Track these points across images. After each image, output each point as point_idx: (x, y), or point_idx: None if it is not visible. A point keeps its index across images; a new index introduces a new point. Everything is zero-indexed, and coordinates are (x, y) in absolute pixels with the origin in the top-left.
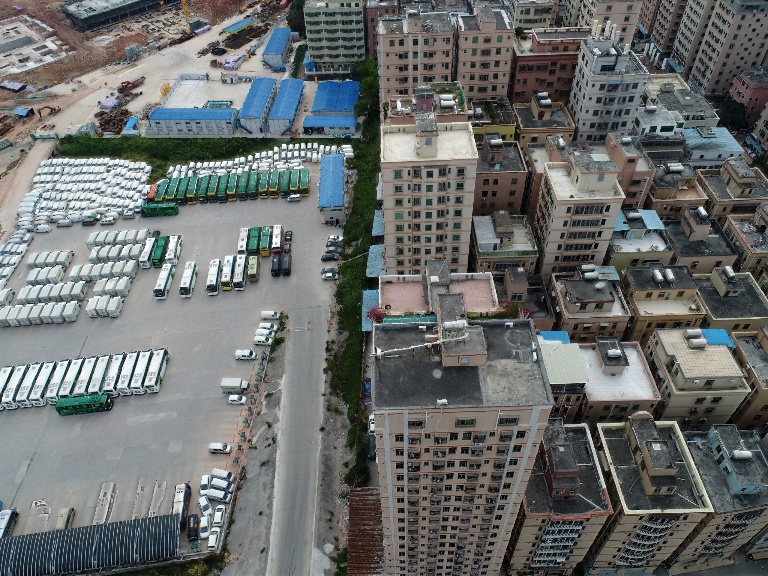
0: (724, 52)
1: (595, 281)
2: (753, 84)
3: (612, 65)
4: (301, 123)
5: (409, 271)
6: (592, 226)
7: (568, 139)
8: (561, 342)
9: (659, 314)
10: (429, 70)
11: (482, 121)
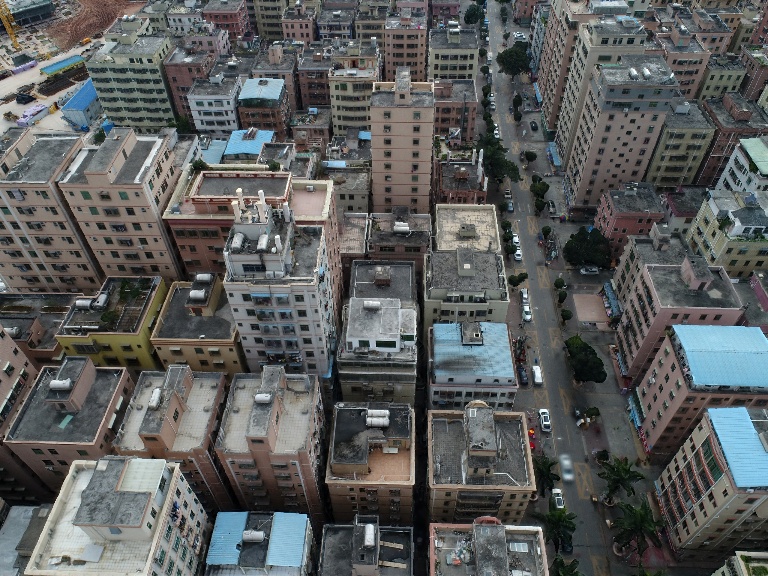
0: (592, 157)
1: None
2: (616, 213)
3: (260, 264)
4: None
5: None
6: None
7: (230, 353)
8: None
9: None
10: (38, 230)
11: (85, 326)
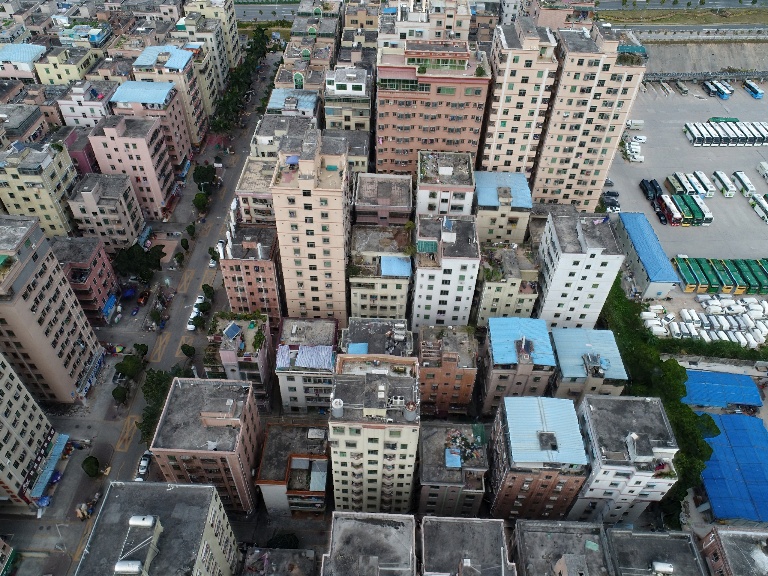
0: None
1: None
2: None
3: None
4: (767, 414)
5: None
6: None
7: None
8: None
9: None
10: None
11: None
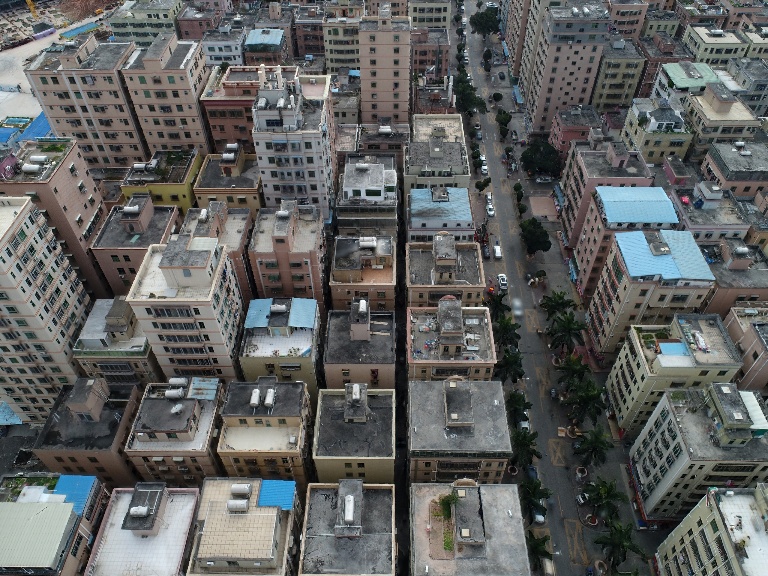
0: (545, 86)
1: (180, 400)
2: (562, 126)
3: (279, 120)
4: None
5: (1, 367)
6: (188, 329)
7: (254, 202)
8: (64, 497)
9: (239, 450)
10: (102, 112)
11: None
